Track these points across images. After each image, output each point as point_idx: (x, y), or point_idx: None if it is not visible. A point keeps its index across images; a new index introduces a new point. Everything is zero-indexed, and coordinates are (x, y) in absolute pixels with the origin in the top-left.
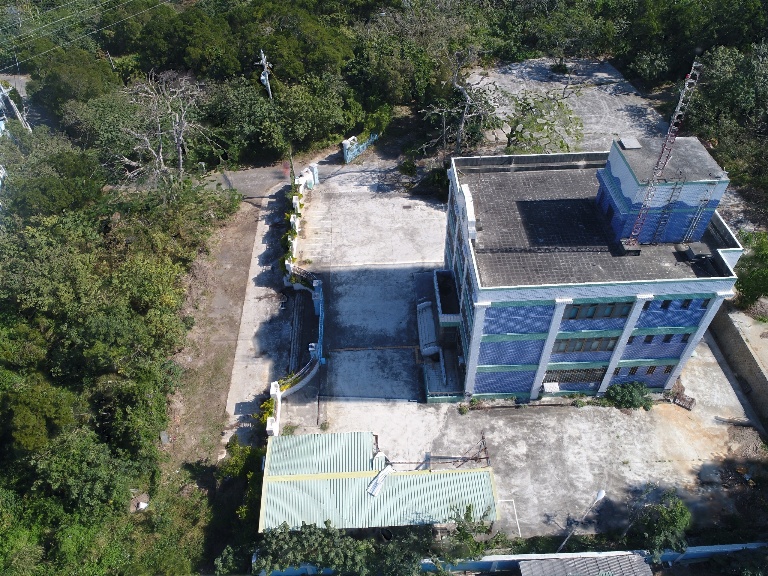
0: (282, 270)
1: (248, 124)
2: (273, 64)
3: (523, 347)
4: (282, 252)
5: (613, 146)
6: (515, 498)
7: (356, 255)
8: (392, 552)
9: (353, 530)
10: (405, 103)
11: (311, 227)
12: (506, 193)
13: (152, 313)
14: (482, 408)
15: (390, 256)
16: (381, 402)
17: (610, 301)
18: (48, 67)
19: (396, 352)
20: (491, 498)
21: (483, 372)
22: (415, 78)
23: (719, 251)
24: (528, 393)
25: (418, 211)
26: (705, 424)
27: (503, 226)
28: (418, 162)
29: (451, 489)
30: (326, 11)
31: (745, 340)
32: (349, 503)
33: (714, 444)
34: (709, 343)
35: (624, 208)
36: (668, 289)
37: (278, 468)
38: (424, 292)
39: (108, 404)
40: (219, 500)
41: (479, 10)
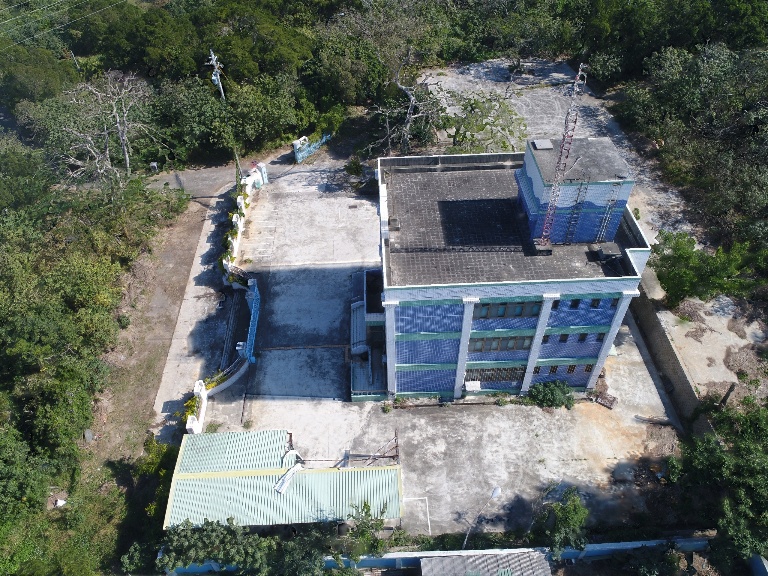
0: (221, 269)
1: (198, 124)
2: (228, 64)
3: (439, 346)
4: (225, 251)
5: (527, 146)
6: (429, 496)
7: (297, 255)
8: (292, 549)
9: (265, 527)
10: (361, 103)
11: (255, 227)
12: (429, 193)
13: (83, 312)
14: (405, 407)
15: (330, 256)
16: (306, 401)
17: (518, 300)
18: (4, 67)
19: (326, 351)
20: (396, 496)
21: (403, 371)
22: (369, 78)
23: (627, 251)
24: (451, 392)
25: (363, 211)
26: (624, 423)
27: (421, 226)
28: (368, 162)
29: (358, 487)
30: (290, 11)
31: (670, 339)
32: (255, 500)
33: (631, 443)
34: (637, 342)
35: (534, 208)
36: (574, 288)
37: (189, 466)
38: (360, 291)
39: (31, 402)
40: (135, 497)
41: (441, 10)
